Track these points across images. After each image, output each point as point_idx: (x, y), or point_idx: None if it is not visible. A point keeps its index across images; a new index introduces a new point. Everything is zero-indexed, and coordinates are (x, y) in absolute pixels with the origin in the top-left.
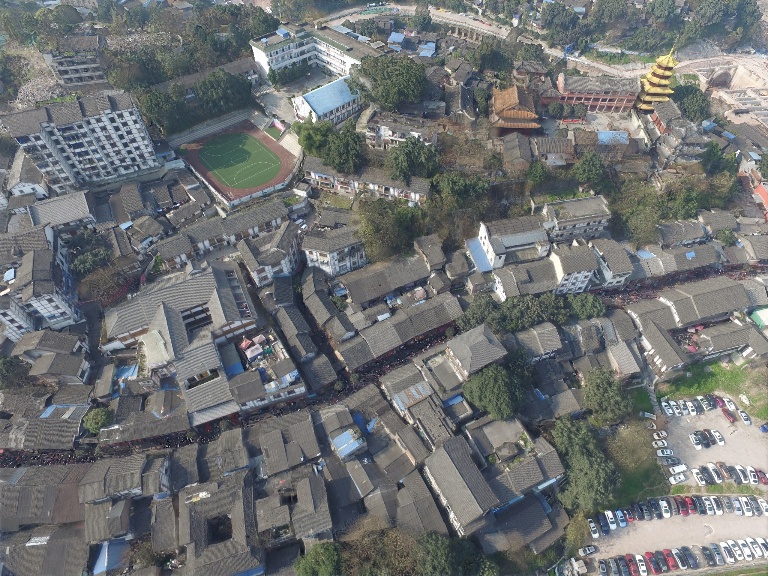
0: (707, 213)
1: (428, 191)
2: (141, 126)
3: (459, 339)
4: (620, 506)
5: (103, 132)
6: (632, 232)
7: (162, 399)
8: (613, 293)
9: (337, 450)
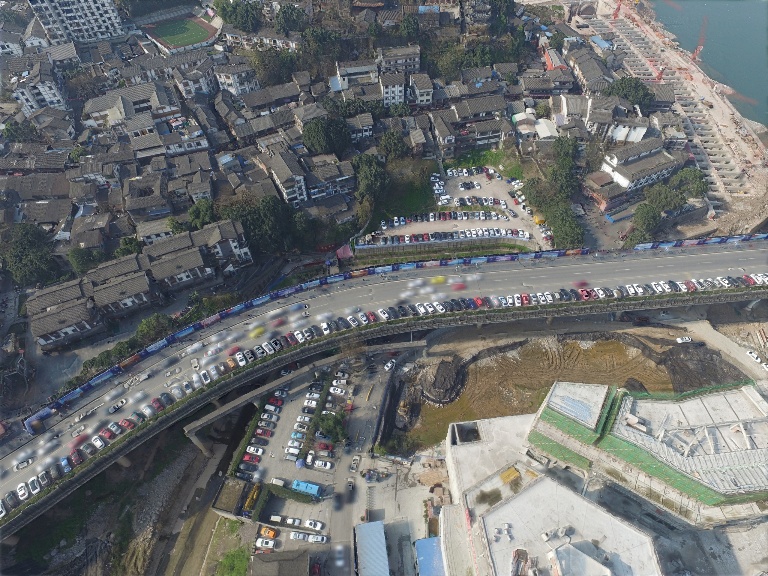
0: (499, 63)
1: (299, 39)
2: (111, 1)
3: (300, 107)
4: (405, 217)
5: (86, 3)
6: (440, 70)
7: (118, 146)
8: (427, 110)
9: (220, 162)
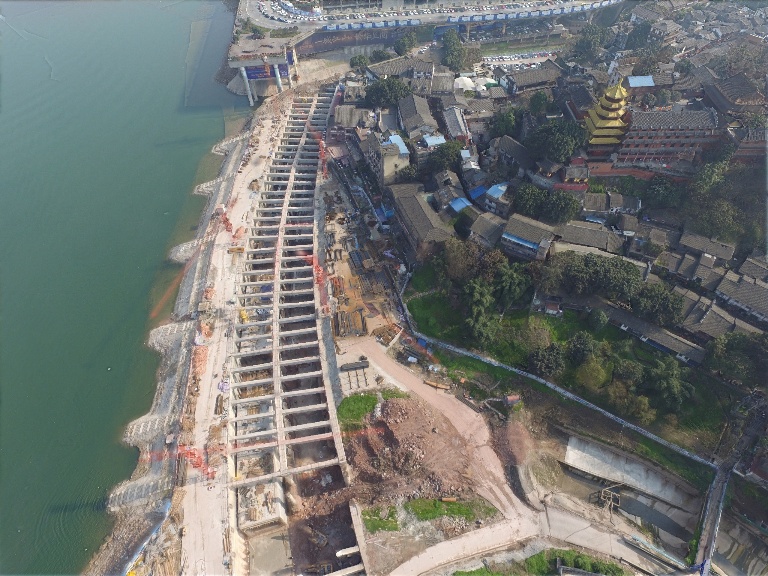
0: None
1: None
2: None
3: (677, 25)
4: None
5: None
6: None
7: None
8: None
9: None
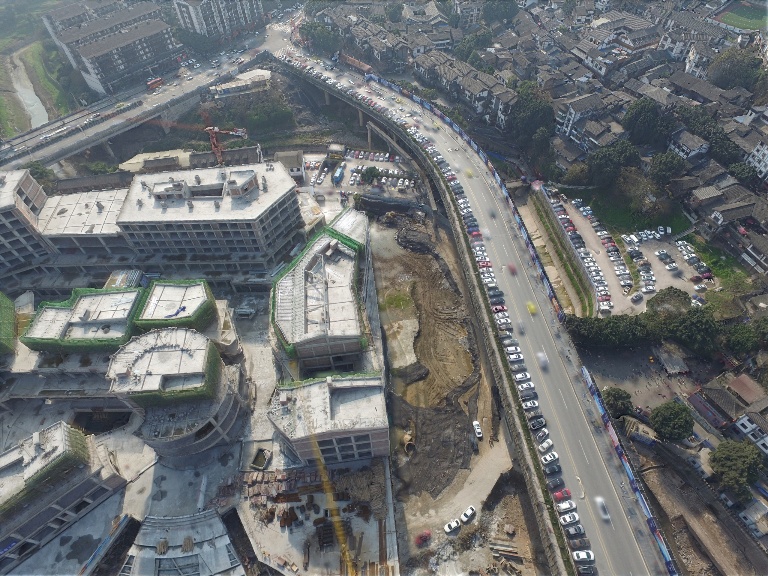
0: None
1: None
2: None
3: None
4: (595, 215)
5: None
6: None
7: None
8: None
9: (579, 78)
